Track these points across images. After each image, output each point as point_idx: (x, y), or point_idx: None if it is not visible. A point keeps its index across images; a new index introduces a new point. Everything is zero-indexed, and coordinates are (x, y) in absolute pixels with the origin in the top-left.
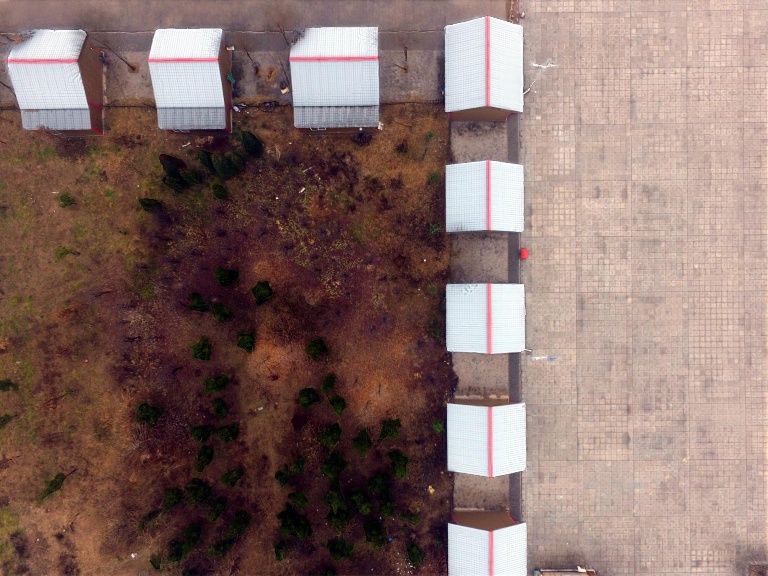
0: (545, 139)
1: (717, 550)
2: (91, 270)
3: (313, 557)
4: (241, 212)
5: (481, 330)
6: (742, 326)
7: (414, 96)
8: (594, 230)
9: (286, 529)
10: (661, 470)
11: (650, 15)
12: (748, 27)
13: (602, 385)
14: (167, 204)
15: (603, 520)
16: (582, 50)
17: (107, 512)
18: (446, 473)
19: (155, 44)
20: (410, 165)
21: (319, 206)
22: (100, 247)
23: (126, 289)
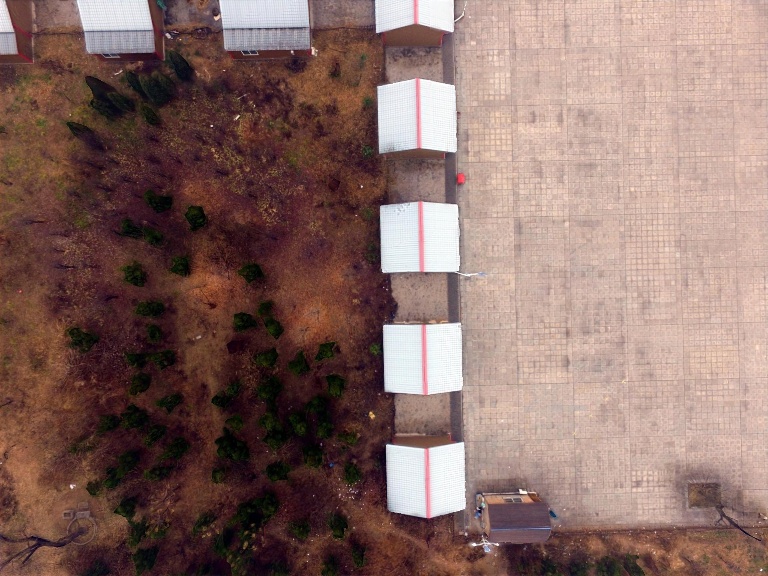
0: (480, 64)
1: (657, 470)
2: (24, 200)
3: (254, 485)
4: (175, 140)
5: (414, 249)
6: (678, 248)
7: (348, 22)
8: (531, 155)
9: (221, 451)
10: (600, 392)
11: None
12: None
13: (541, 309)
14: (100, 133)
15: (544, 443)
16: None
17: (44, 443)
18: (383, 394)
19: None
20: (345, 91)
21: (254, 133)
22: (32, 177)
23: (60, 219)
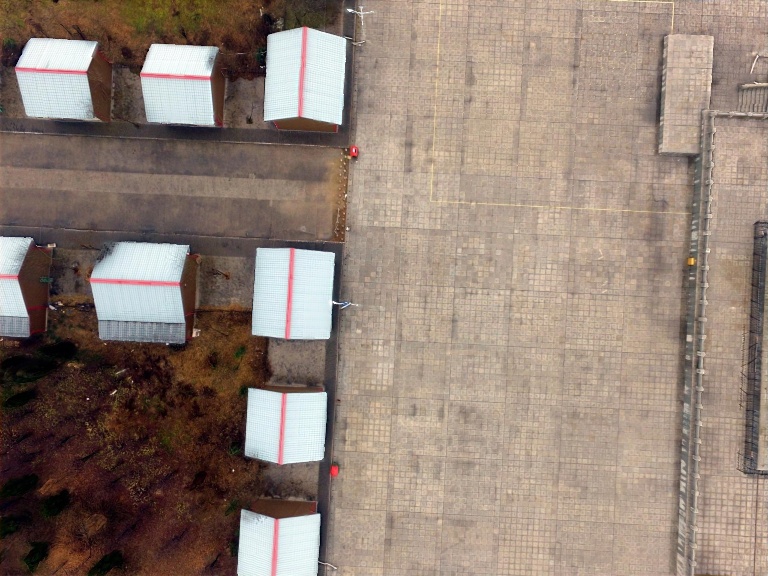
0: (364, 353)
1: None
2: None
3: None
4: (50, 411)
5: (267, 564)
6: (553, 556)
7: (234, 303)
8: (408, 448)
9: None
10: None
11: (477, 235)
12: (574, 253)
13: None
14: None
15: None
16: (407, 266)
17: None
18: None
19: None
20: (225, 373)
21: (129, 410)
22: None
23: None
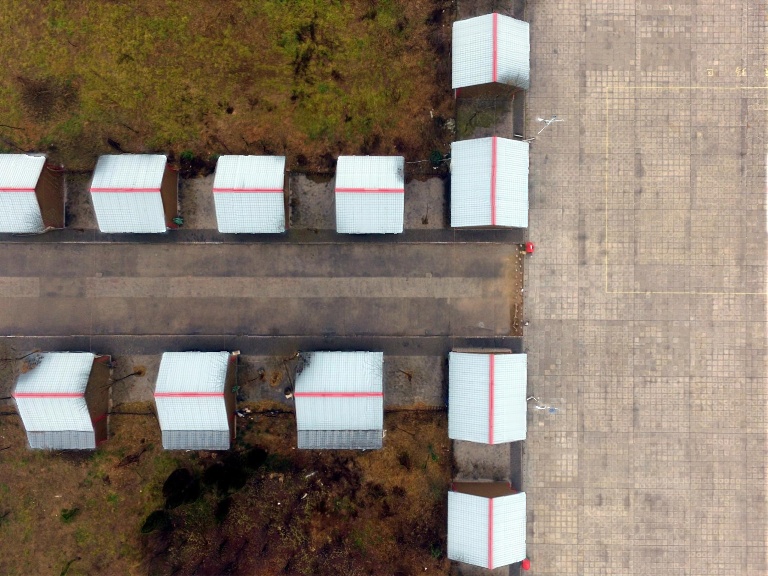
0: (548, 445)
1: None
2: (91, 575)
3: None
4: (243, 518)
5: None
6: None
7: (418, 402)
8: (596, 538)
9: None
10: None
11: (653, 324)
12: (751, 338)
13: None
14: (169, 510)
15: None
16: (585, 357)
17: None
18: None
19: (162, 374)
20: (412, 472)
21: (321, 513)
22: (101, 552)
23: None
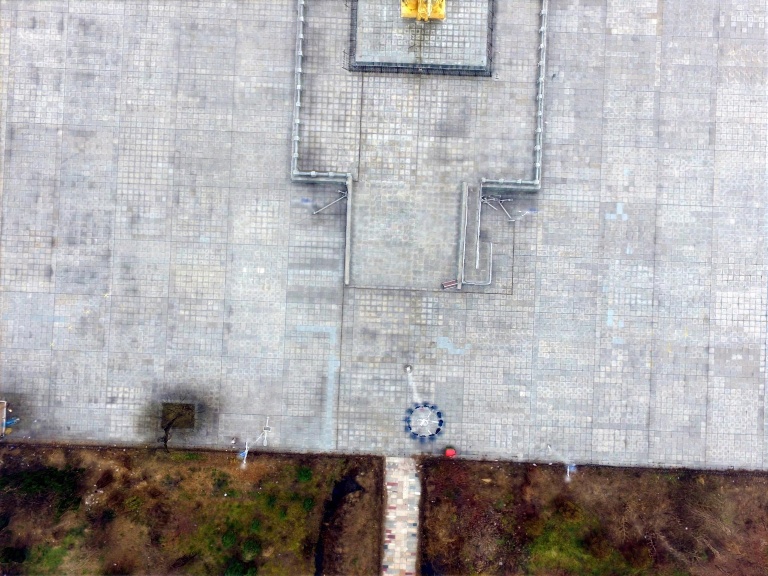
0: None
1: (133, 387)
2: None
3: None
4: None
5: None
6: (172, 164)
7: None
8: (28, 60)
9: None
10: (82, 304)
11: None
12: None
13: (27, 216)
14: None
15: (20, 352)
16: None
17: None
18: None
19: None
20: None
21: None
22: None
23: None
